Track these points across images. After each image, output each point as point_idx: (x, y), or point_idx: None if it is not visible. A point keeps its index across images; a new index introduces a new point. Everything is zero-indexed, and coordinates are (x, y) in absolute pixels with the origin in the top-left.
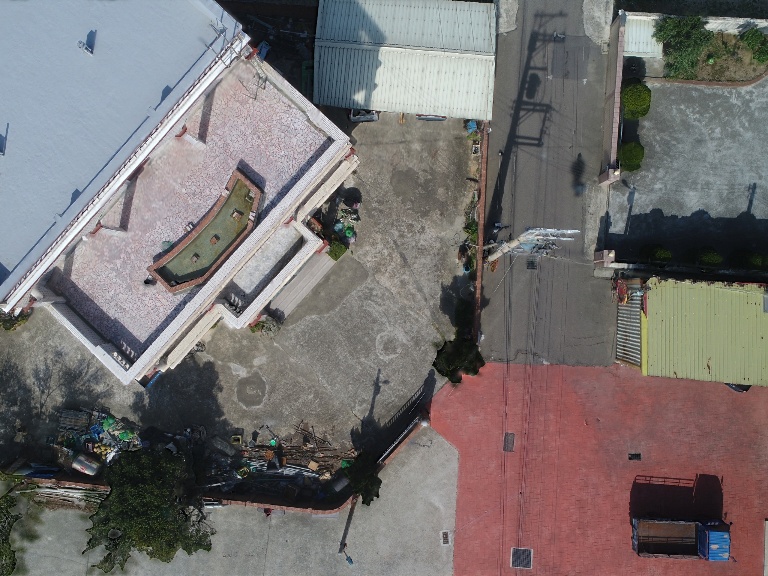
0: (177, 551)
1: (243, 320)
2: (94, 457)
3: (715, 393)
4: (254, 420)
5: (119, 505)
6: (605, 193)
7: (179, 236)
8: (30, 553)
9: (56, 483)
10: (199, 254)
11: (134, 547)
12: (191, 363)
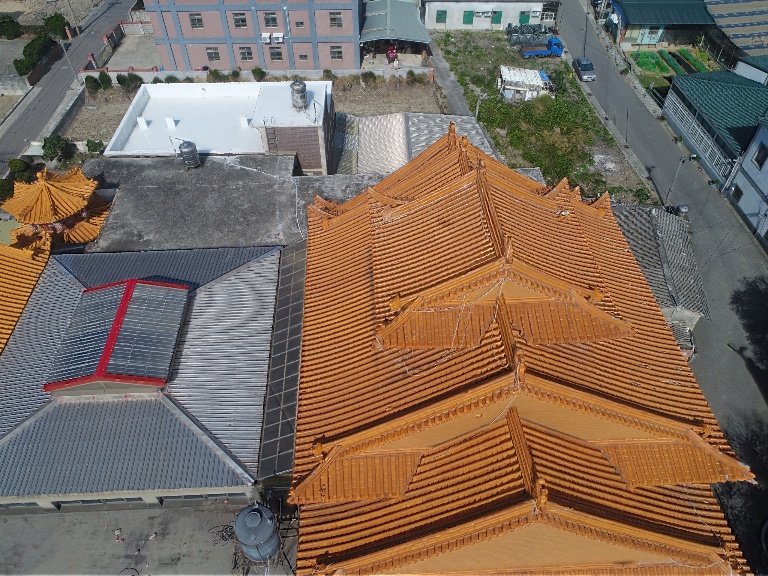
0: None
1: None
2: None
3: None
4: None
5: None
6: None
7: None
8: None
9: None
10: None
11: None
12: None
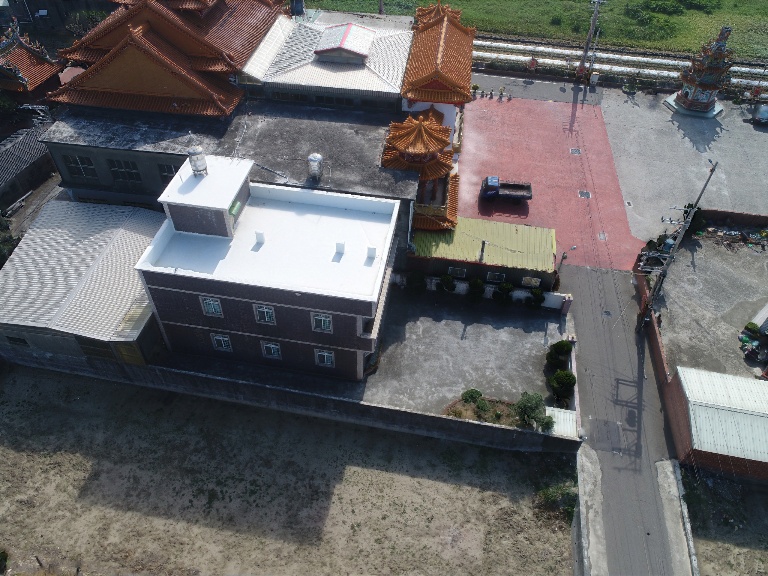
0: None
1: None
2: None
3: None
4: (767, 256)
5: None
6: None
7: None
8: None
9: None
10: None
11: None
12: None
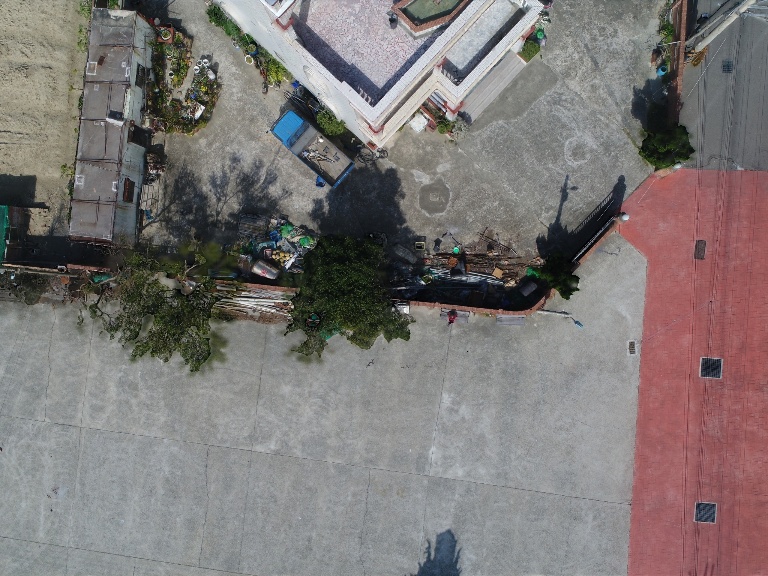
0: (354, 362)
1: (463, 88)
2: (272, 264)
3: None
4: (437, 227)
5: (326, 282)
6: None
7: None
8: (201, 365)
9: (232, 291)
10: None
11: (336, 331)
12: (373, 170)
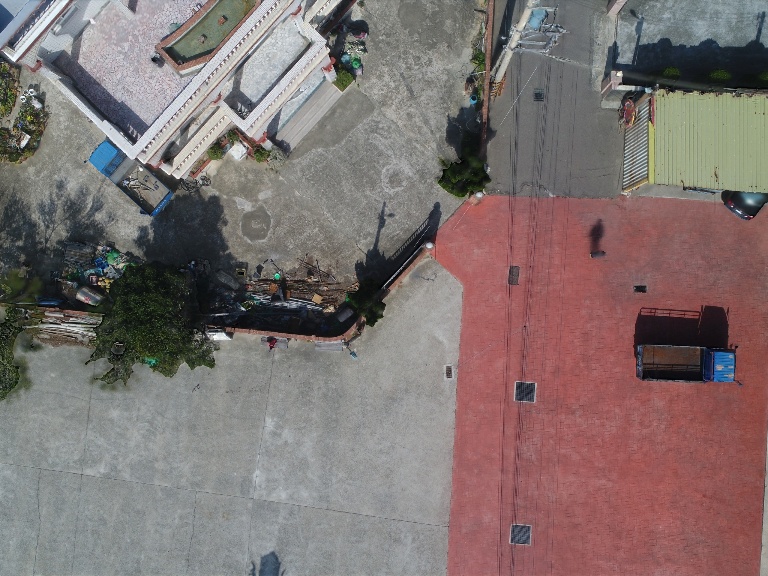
0: (180, 387)
1: (249, 122)
2: (98, 291)
3: (722, 224)
4: (258, 254)
5: (123, 312)
6: (613, 23)
7: (187, 18)
8: (33, 390)
9: (60, 317)
10: (207, 35)
11: (137, 359)
12: (196, 197)
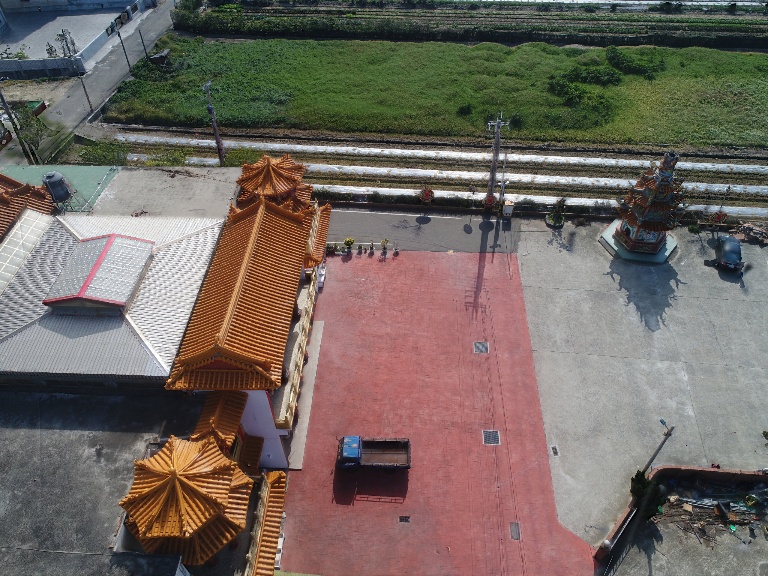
0: None
1: None
2: None
3: None
4: (760, 549)
5: None
6: None
7: None
8: None
9: None
10: None
11: None
12: None
